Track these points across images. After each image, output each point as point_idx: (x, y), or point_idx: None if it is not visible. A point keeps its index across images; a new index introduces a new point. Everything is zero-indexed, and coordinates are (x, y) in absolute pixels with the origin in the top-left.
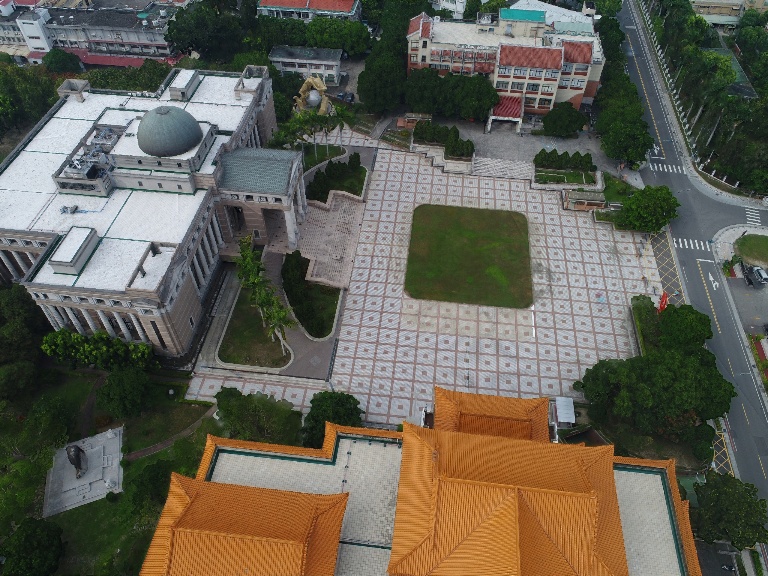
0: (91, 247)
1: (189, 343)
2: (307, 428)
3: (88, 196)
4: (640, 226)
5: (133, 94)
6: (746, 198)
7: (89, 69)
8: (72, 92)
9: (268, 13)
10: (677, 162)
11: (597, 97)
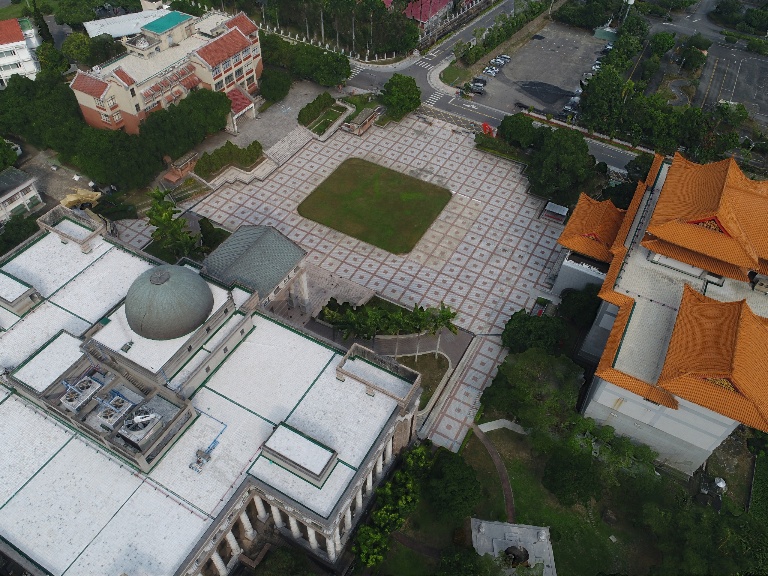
0: None
1: None
2: None
3: (181, 438)
4: (413, 107)
5: None
6: (407, 59)
7: None
8: None
9: None
10: (351, 66)
11: (265, 57)
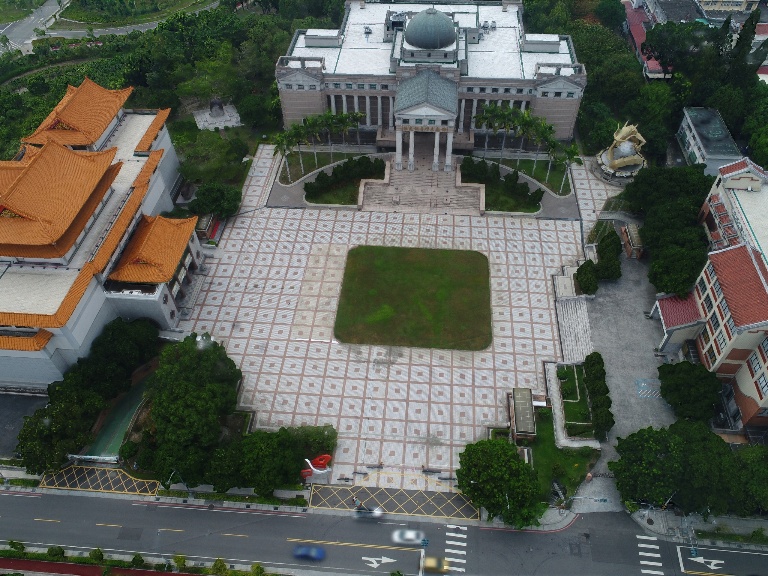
0: (328, 43)
1: None
2: None
3: None
4: None
5: None
6: None
7: None
8: None
9: None
10: None
11: None
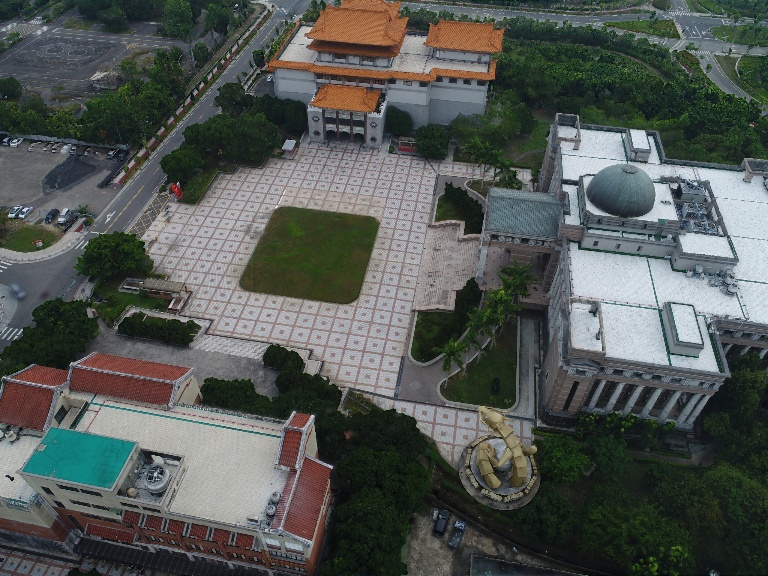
0: None
1: None
2: None
3: None
4: None
5: None
6: None
7: None
8: None
9: None
10: None
11: None
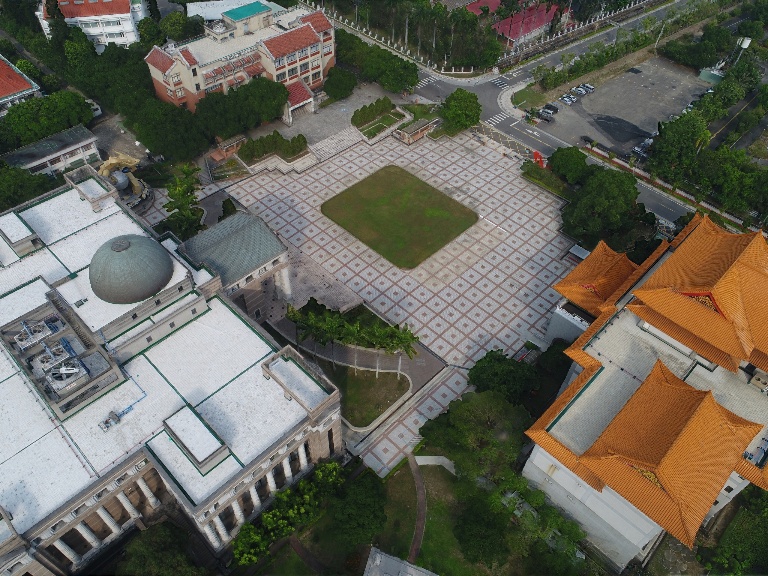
0: None
1: None
2: (505, 393)
3: (103, 396)
4: (469, 124)
5: None
6: (484, 75)
7: None
8: None
9: None
10: (425, 75)
11: (340, 55)
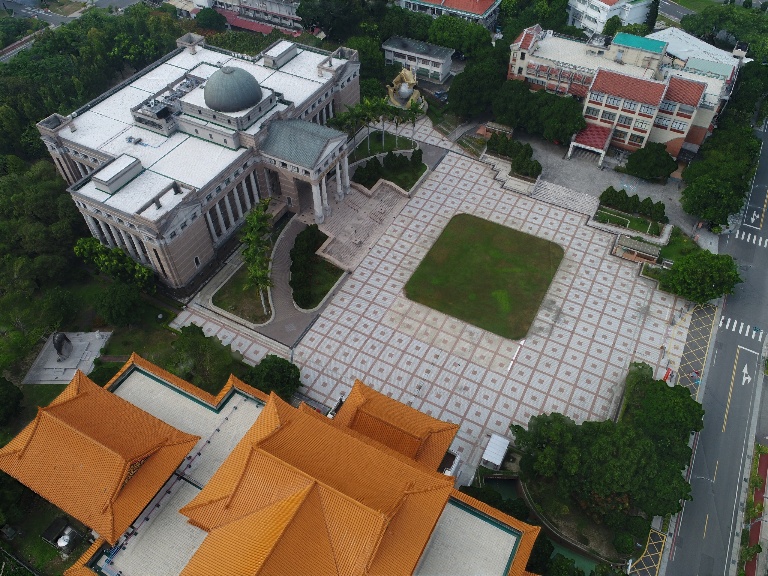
0: (132, 174)
1: (189, 279)
2: None
3: (154, 133)
4: (682, 292)
5: (235, 55)
6: None
7: (233, 30)
8: (187, 44)
9: (406, 5)
10: None
11: (702, 145)
